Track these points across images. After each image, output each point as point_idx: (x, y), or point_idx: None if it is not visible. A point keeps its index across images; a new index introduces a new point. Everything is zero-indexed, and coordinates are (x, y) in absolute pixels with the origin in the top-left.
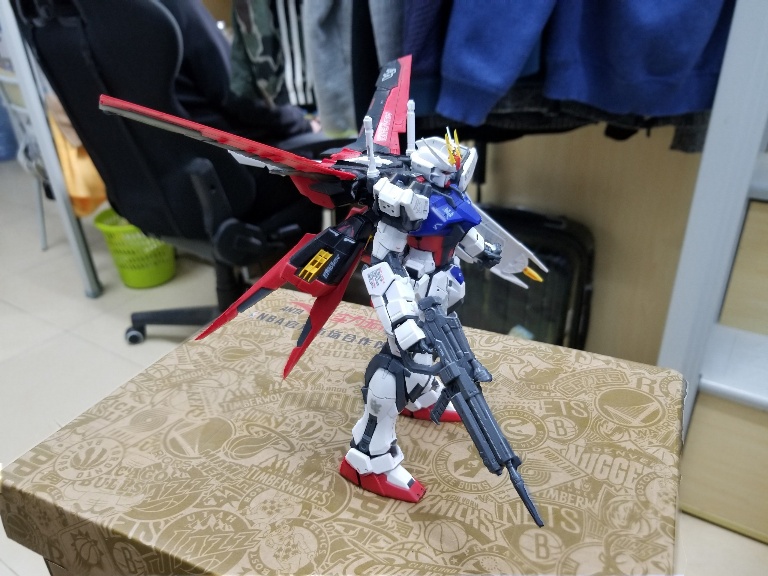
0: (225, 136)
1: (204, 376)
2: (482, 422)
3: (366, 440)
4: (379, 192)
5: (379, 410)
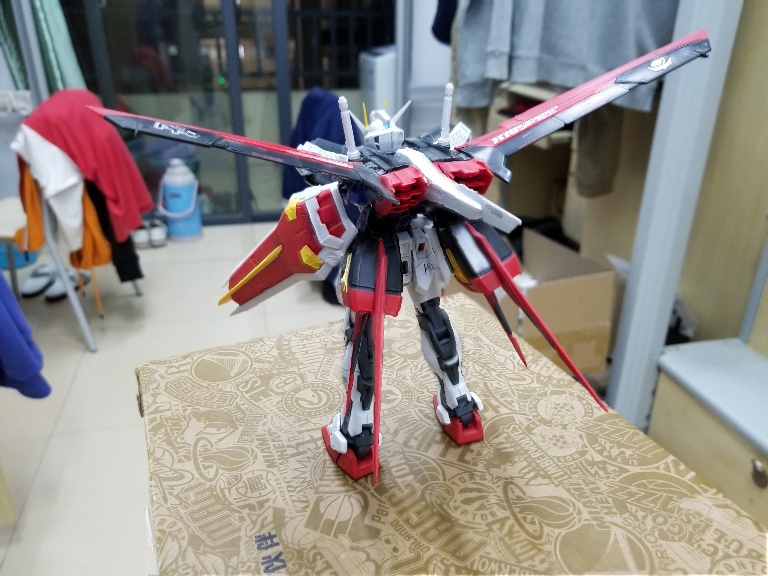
0: (594, 87)
1: None
2: None
3: None
4: None
5: None
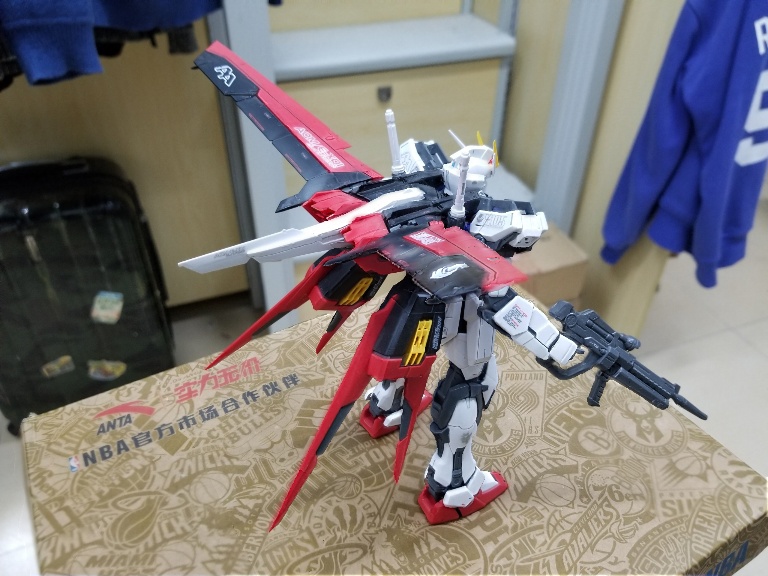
0: None
1: None
2: (648, 378)
3: (459, 474)
4: (522, 229)
5: (469, 439)
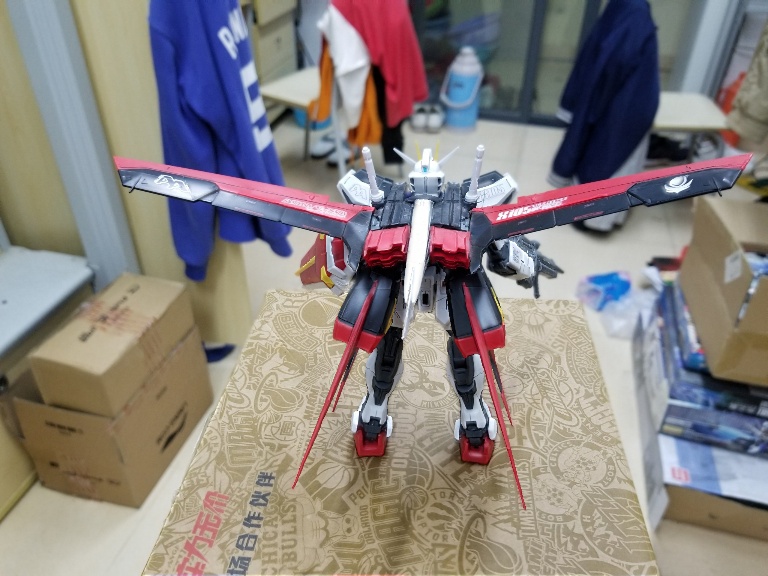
0: None
1: None
2: None
3: None
4: None
5: None
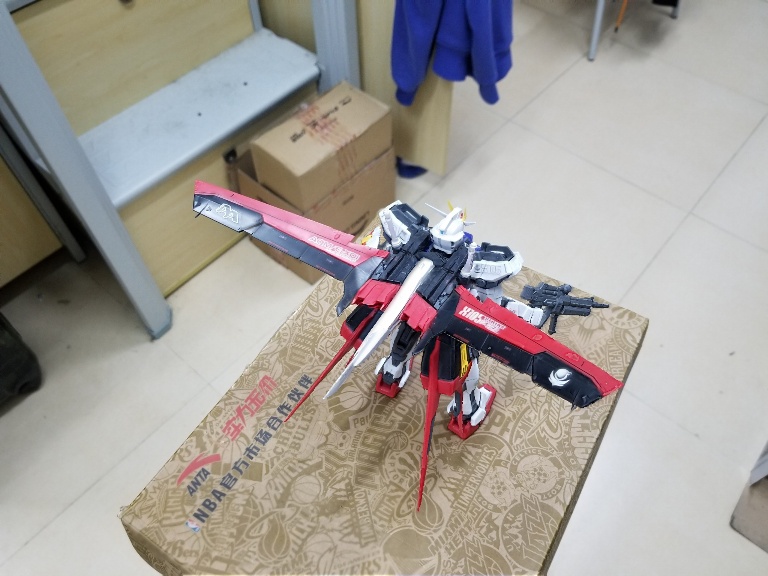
0: None
1: (312, 570)
2: None
3: None
4: (513, 272)
5: None
